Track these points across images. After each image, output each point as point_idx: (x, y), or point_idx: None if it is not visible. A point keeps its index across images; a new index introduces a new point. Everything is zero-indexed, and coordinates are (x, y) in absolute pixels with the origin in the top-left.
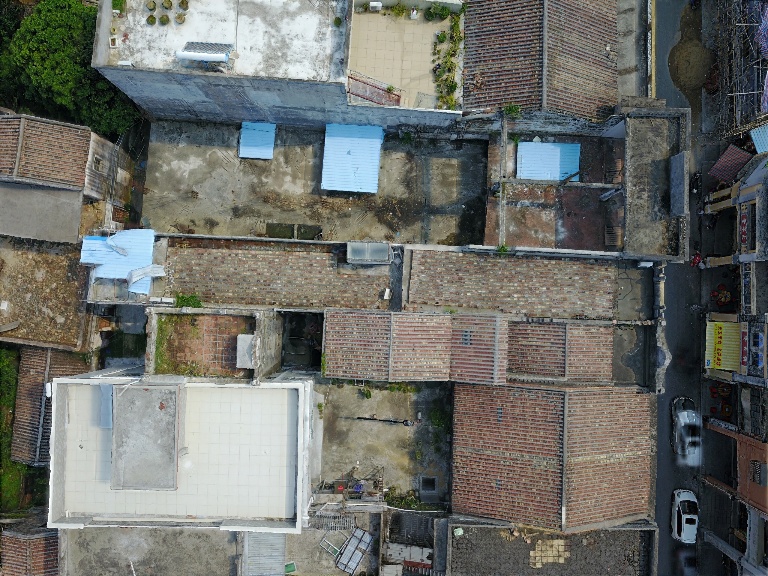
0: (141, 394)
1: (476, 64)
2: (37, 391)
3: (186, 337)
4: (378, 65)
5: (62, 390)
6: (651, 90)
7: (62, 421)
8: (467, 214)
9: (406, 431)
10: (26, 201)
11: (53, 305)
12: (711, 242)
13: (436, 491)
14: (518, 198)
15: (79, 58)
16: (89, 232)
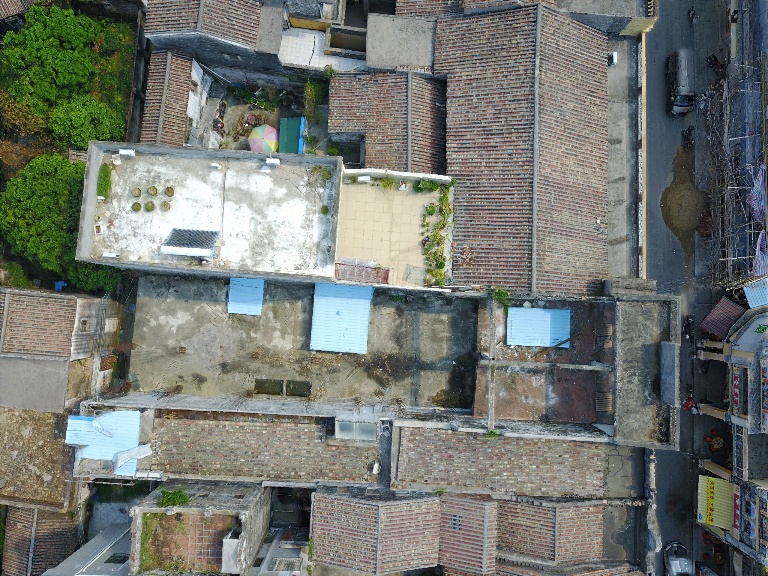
0: None
1: (465, 238)
2: (24, 546)
3: (171, 532)
4: (367, 236)
5: None
6: (642, 263)
7: None
8: (457, 370)
9: None
10: (12, 370)
11: (40, 463)
12: (704, 386)
13: None
14: None
15: (65, 225)
16: (74, 411)
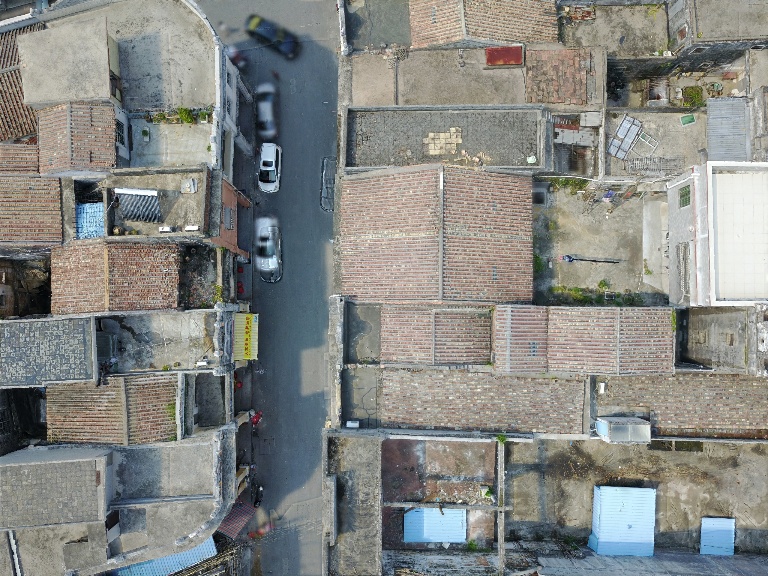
0: None
1: None
2: None
3: None
4: None
5: None
6: None
7: None
8: None
9: (561, 249)
10: None
11: None
12: (242, 436)
13: None
14: (463, 485)
15: None
16: None
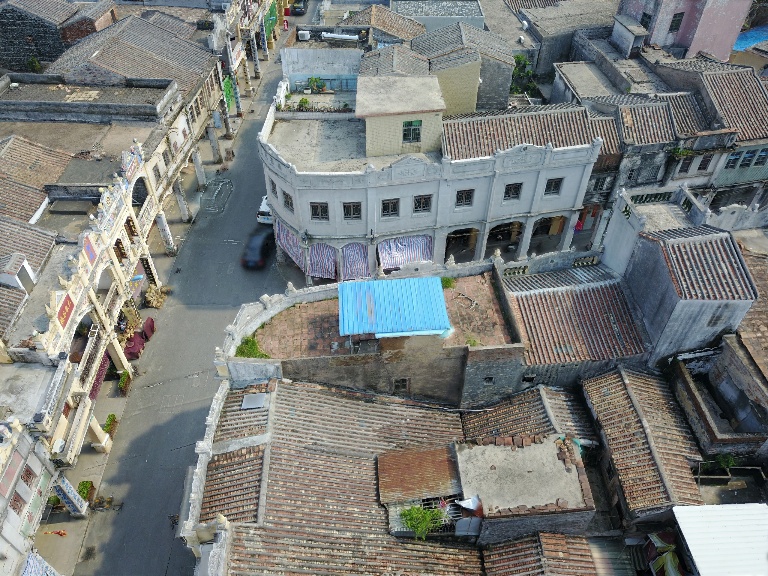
0: None
1: None
2: None
3: None
4: None
5: None
6: None
7: None
8: None
9: None
10: None
11: None
12: None
13: None
14: None
15: None
16: None
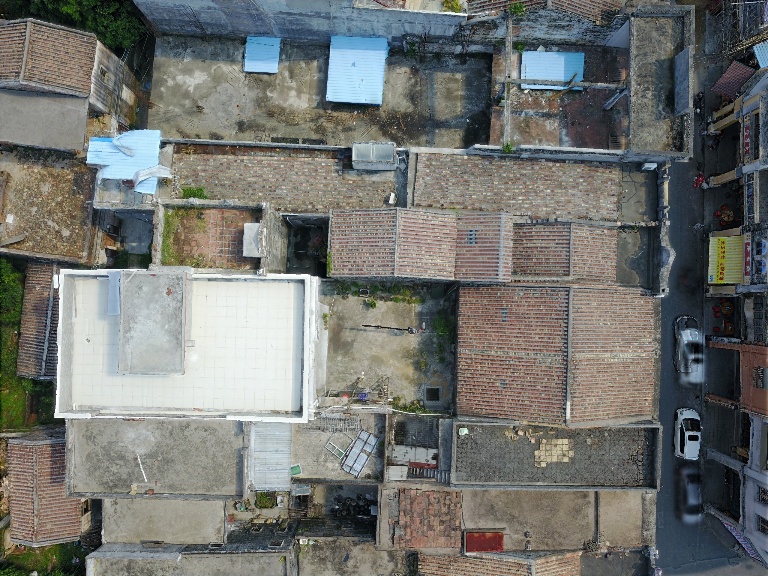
0: (148, 280)
1: None
2: (43, 306)
3: (193, 231)
4: None
5: (69, 283)
6: None
7: (69, 314)
8: (471, 128)
9: (411, 342)
10: (32, 108)
11: (59, 218)
12: (714, 163)
13: (440, 401)
14: (522, 107)
15: None
16: (95, 134)
